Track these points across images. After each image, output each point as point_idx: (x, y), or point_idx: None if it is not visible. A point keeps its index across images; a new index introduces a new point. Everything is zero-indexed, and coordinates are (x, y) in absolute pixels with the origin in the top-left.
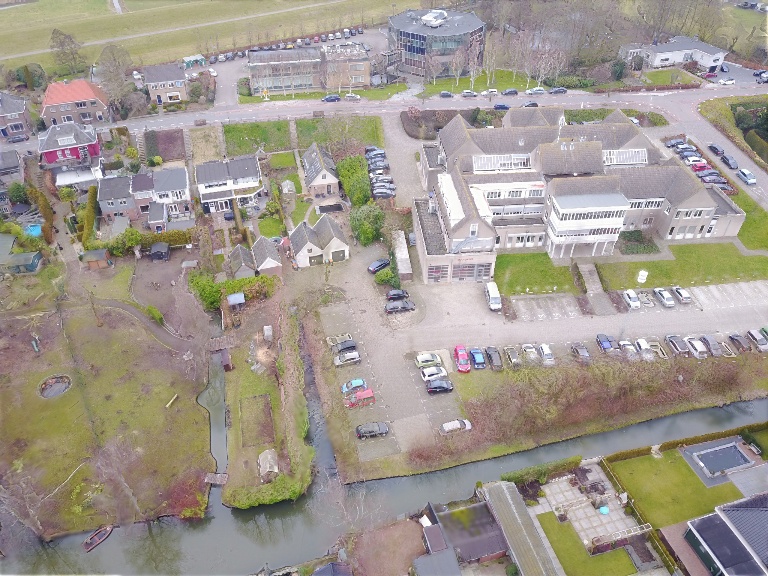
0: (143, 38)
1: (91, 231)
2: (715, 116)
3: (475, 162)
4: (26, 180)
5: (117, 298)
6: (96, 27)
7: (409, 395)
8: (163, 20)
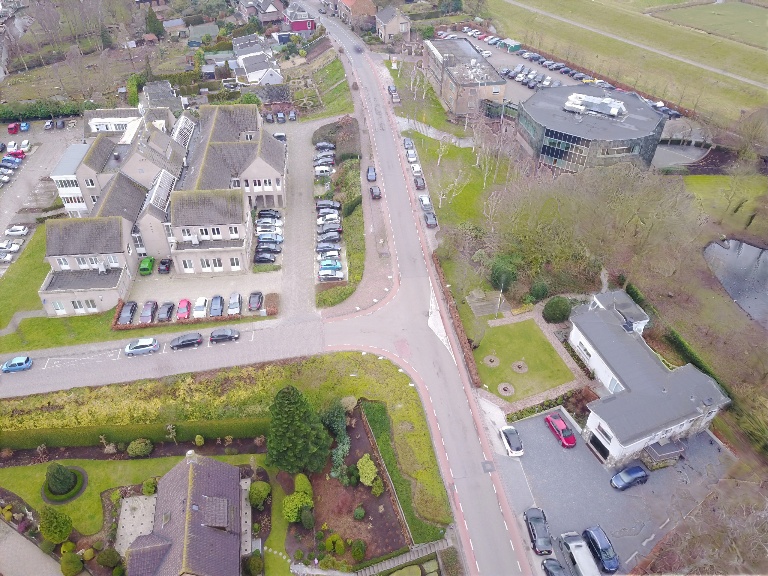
0: (556, 21)
1: (215, 49)
2: (332, 363)
3: (179, 120)
4: (268, 22)
5: (155, 69)
6: (559, 1)
7: (6, 143)
8: (603, 19)
